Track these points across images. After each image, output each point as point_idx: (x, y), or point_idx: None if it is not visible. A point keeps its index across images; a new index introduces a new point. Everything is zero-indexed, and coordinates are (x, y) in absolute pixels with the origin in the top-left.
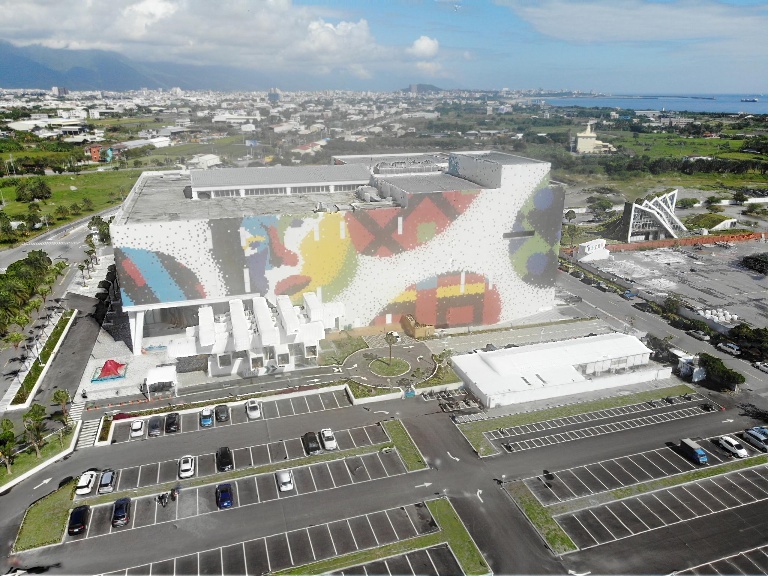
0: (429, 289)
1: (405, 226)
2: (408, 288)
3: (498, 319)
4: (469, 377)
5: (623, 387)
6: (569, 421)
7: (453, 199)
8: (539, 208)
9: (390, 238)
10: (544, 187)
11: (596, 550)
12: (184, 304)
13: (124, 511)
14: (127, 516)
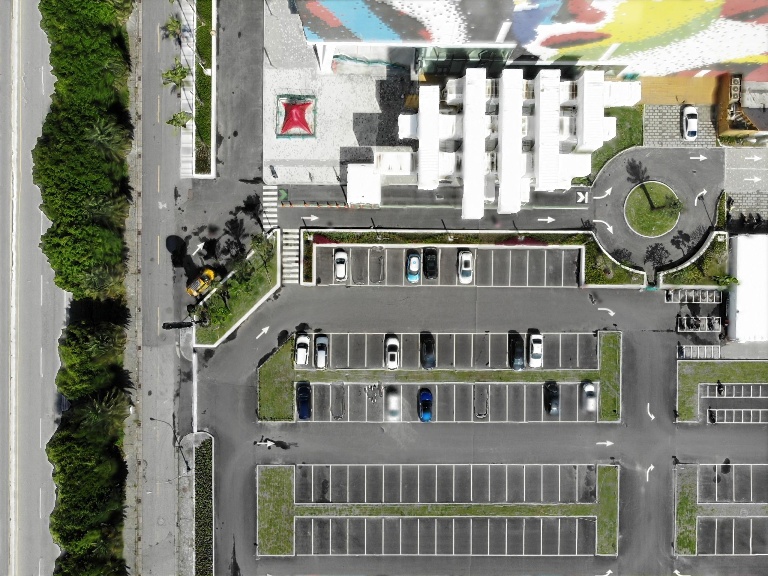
0: None
1: None
2: None
3: None
4: (737, 294)
5: None
6: None
7: None
8: None
9: None
10: None
11: (709, 560)
12: (397, 45)
13: (342, 414)
14: None
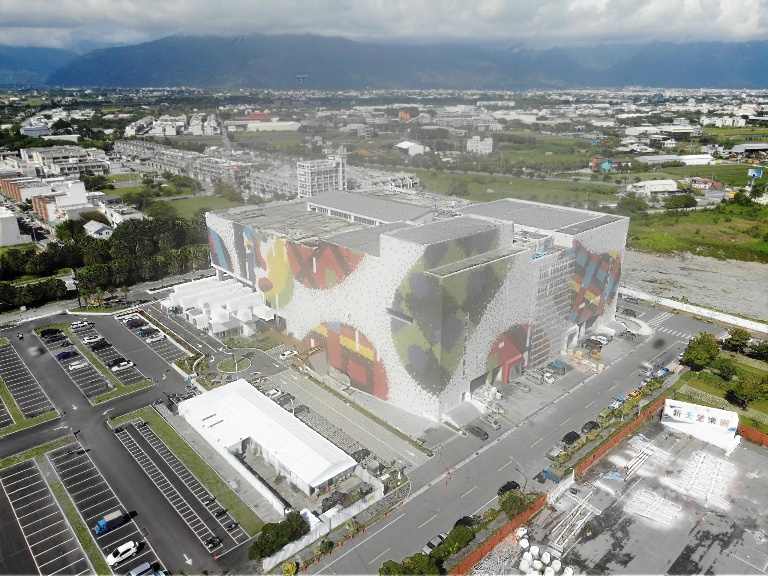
0: None
1: (318, 267)
2: None
3: (387, 397)
4: None
5: (246, 482)
6: (166, 454)
7: (346, 255)
8: (416, 294)
9: (310, 273)
10: (419, 272)
11: None
12: None
13: (49, 337)
14: (50, 340)
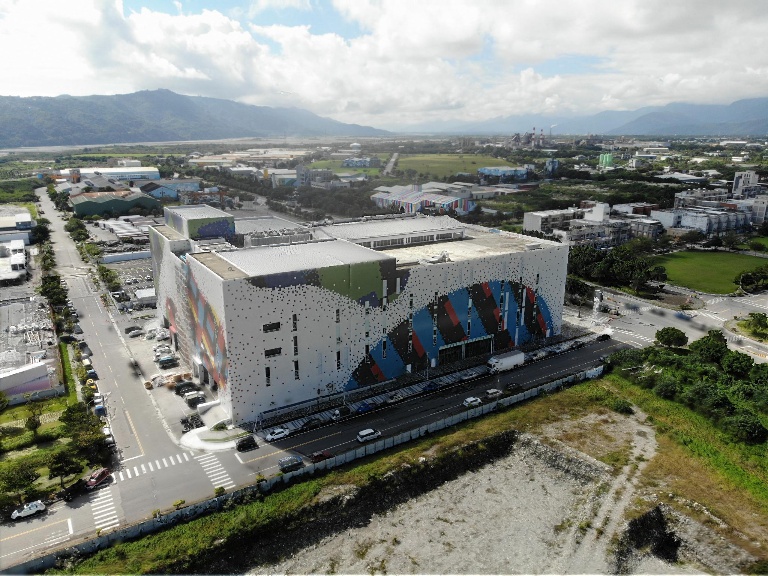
0: None
1: None
2: None
3: None
4: None
5: None
6: None
7: None
8: None
9: None
10: None
11: None
12: None
13: None
14: None
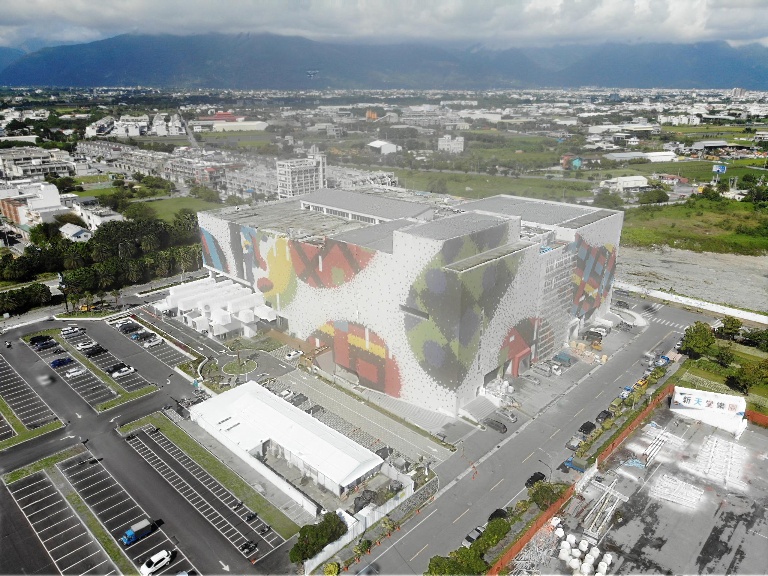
0: (343, 331)
1: (324, 265)
2: (329, 322)
3: (399, 394)
4: None
5: (272, 485)
6: (184, 460)
7: (356, 253)
8: (432, 290)
9: (315, 272)
10: (436, 267)
11: (5, 492)
12: None
13: (40, 344)
14: (41, 347)
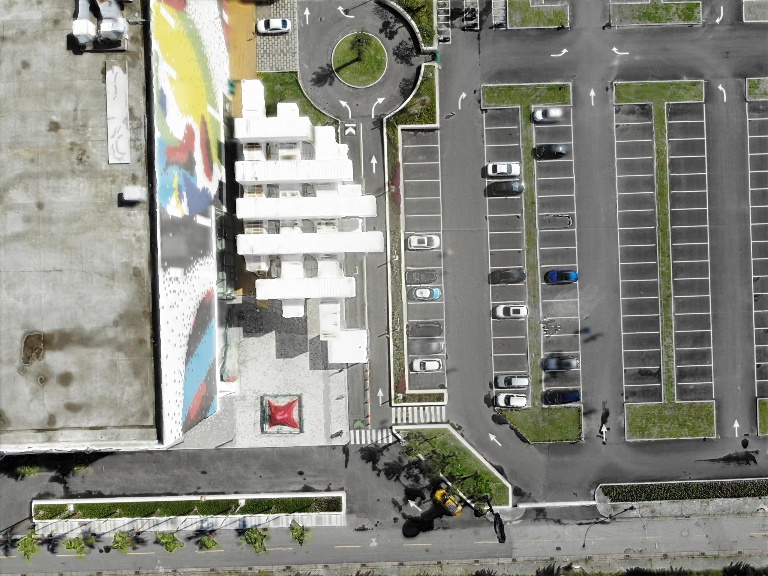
0: None
1: None
2: None
3: None
4: None
5: None
6: None
7: None
8: None
9: None
10: None
11: None
12: None
13: (574, 360)
14: None
